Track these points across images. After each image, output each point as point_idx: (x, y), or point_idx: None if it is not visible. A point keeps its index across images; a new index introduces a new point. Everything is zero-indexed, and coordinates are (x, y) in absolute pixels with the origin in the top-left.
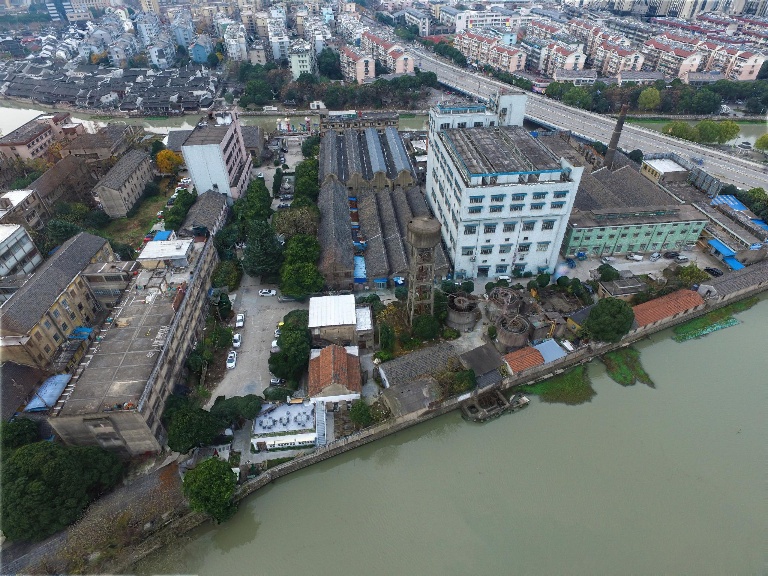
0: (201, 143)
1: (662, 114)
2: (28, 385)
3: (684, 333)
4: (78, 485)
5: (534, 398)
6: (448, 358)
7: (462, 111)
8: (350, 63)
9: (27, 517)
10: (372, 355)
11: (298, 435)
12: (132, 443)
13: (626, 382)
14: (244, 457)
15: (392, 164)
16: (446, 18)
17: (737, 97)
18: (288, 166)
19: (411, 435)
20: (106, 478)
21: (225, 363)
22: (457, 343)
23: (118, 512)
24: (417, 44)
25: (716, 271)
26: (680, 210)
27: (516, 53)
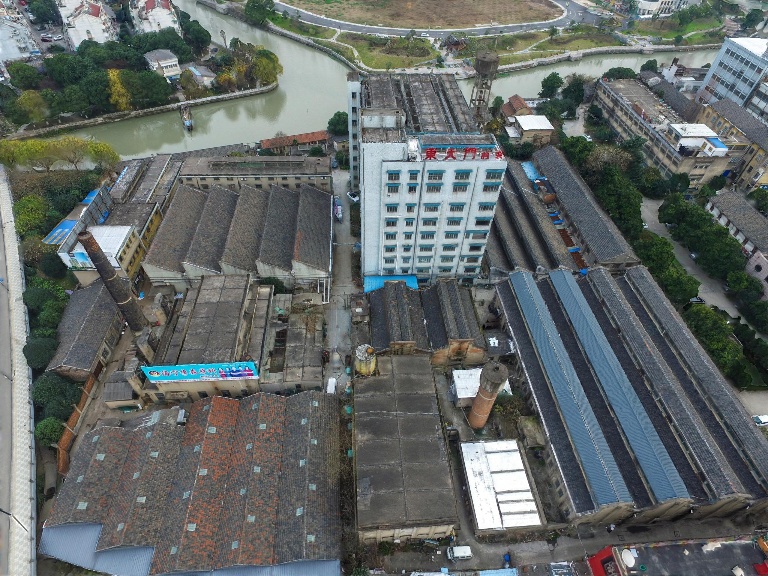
0: None
1: None
2: (688, 120)
3: None
4: None
5: None
6: None
7: None
8: None
9: None
10: None
11: None
12: None
13: None
14: None
15: None
16: None
17: None
18: None
19: None
20: None
21: None
22: None
23: None
24: None
25: None
26: None
27: None
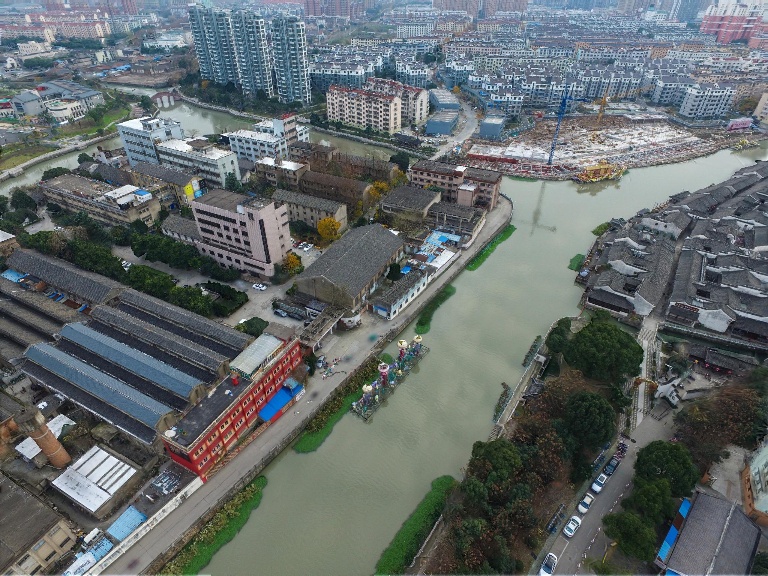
0: (209, 194)
1: None
2: None
3: None
4: None
5: None
6: None
7: None
8: None
9: None
10: None
11: None
12: None
13: None
14: None
15: None
16: None
17: None
18: None
19: None
20: None
21: None
22: None
23: None
24: None
25: None
26: None
27: None
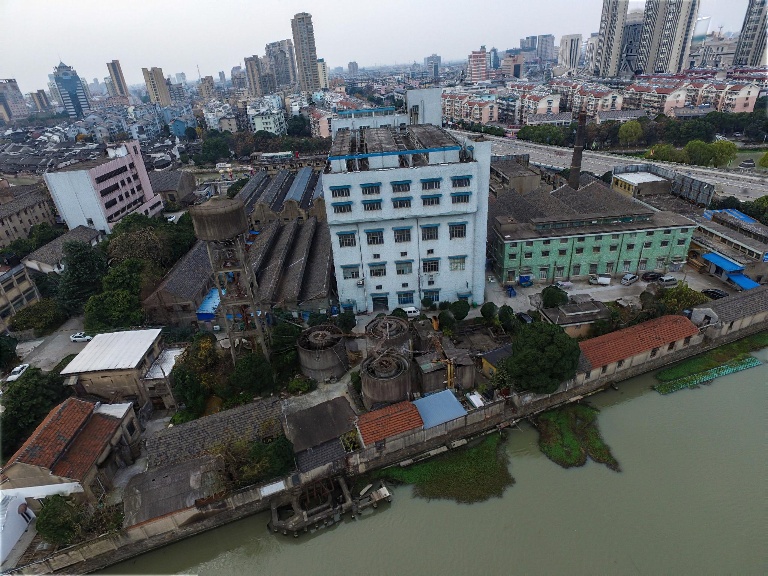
0: (69, 170)
1: (648, 148)
2: None
3: (672, 380)
4: None
5: (404, 490)
6: (265, 420)
7: (366, 114)
8: (314, 122)
9: None
10: (170, 419)
11: None
12: None
13: (569, 460)
14: None
15: None
16: None
17: (734, 130)
18: None
19: (177, 560)
20: None
21: None
22: (306, 399)
23: None
24: None
25: (718, 292)
26: (655, 214)
27: (487, 104)
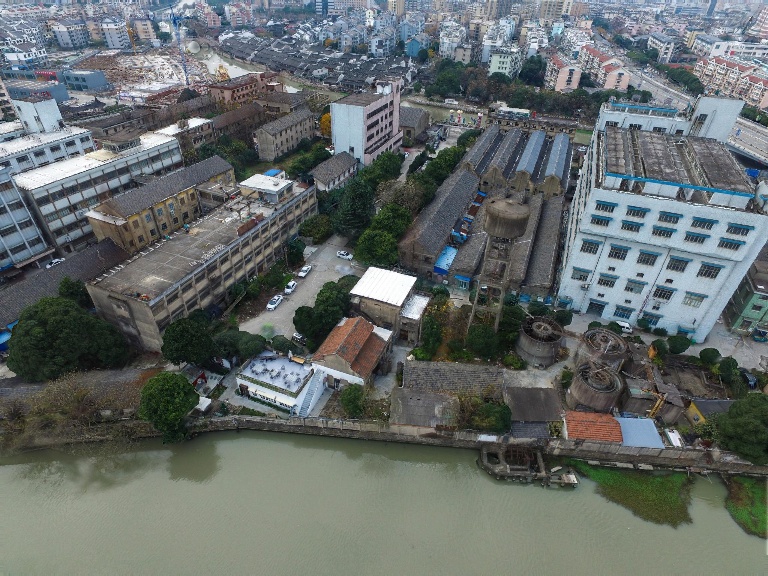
0: (350, 103)
1: None
2: (112, 262)
3: None
4: (73, 348)
5: (588, 483)
6: (489, 384)
7: (642, 111)
8: (553, 70)
9: (21, 355)
10: (410, 350)
11: (279, 393)
12: (145, 337)
13: (753, 528)
14: (226, 394)
15: (545, 169)
16: (700, 47)
17: None
18: (437, 152)
19: (408, 454)
20: (103, 355)
21: (267, 303)
22: (516, 375)
23: (91, 388)
24: (649, 69)
25: None
26: None
27: None
